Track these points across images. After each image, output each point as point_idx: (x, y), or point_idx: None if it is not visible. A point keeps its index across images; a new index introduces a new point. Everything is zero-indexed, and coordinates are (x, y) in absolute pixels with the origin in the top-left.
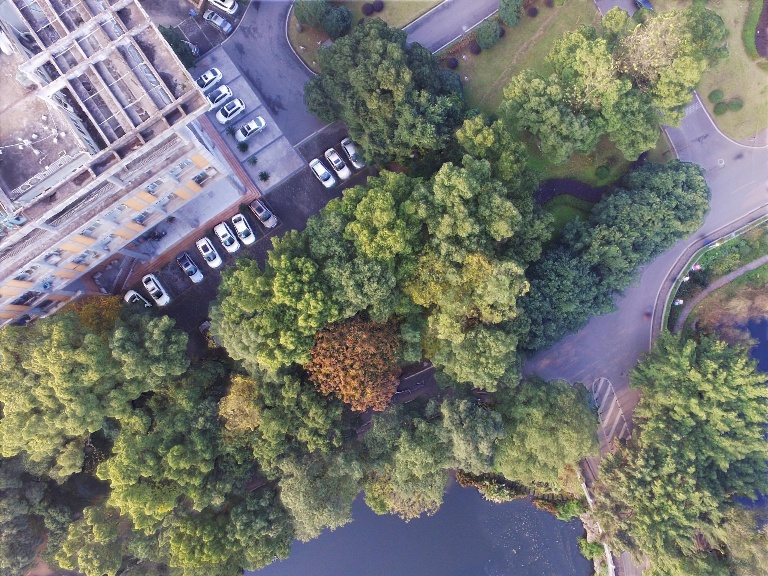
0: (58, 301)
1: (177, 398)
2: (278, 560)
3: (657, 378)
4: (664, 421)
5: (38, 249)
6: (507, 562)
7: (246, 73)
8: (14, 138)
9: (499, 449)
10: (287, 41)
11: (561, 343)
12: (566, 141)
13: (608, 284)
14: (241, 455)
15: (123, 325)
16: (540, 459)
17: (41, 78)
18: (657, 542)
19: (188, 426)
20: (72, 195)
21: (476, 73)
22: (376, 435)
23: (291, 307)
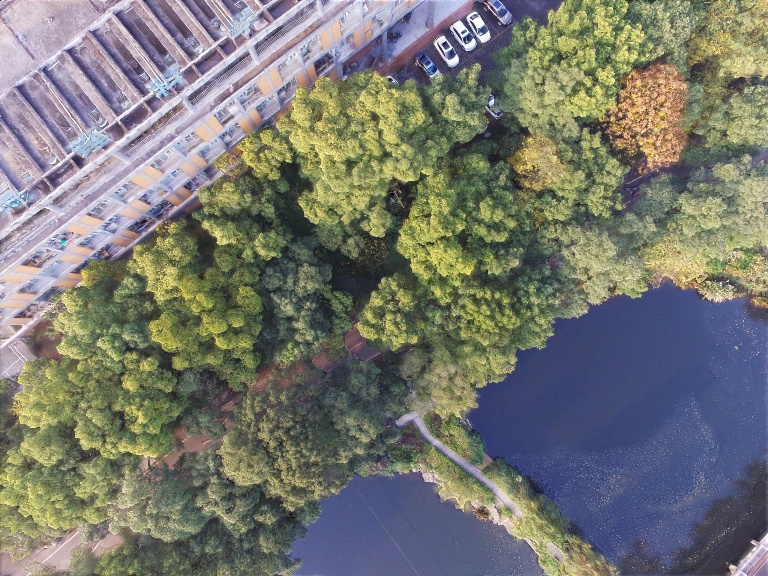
0: None
1: (469, 164)
2: None
3: None
4: None
5: None
6: (730, 358)
7: None
8: None
9: None
10: None
11: None
12: None
13: None
14: (529, 221)
15: (417, 88)
16: None
17: None
18: None
19: (487, 187)
20: None
21: None
22: (652, 201)
23: (605, 45)
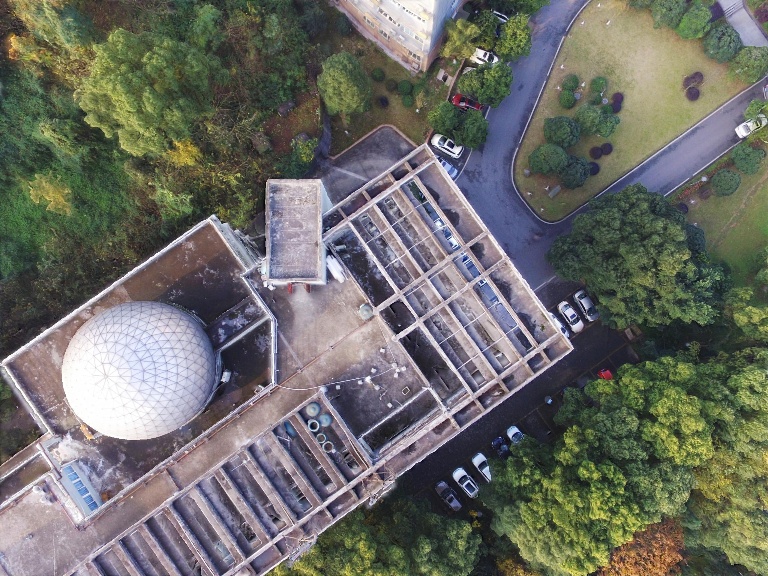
0: None
1: None
2: None
3: None
4: None
5: None
6: None
7: None
8: (352, 372)
9: None
10: (513, 186)
11: None
12: None
13: None
14: None
15: (407, 521)
16: None
17: None
18: None
19: None
20: None
21: (705, 218)
22: None
23: None
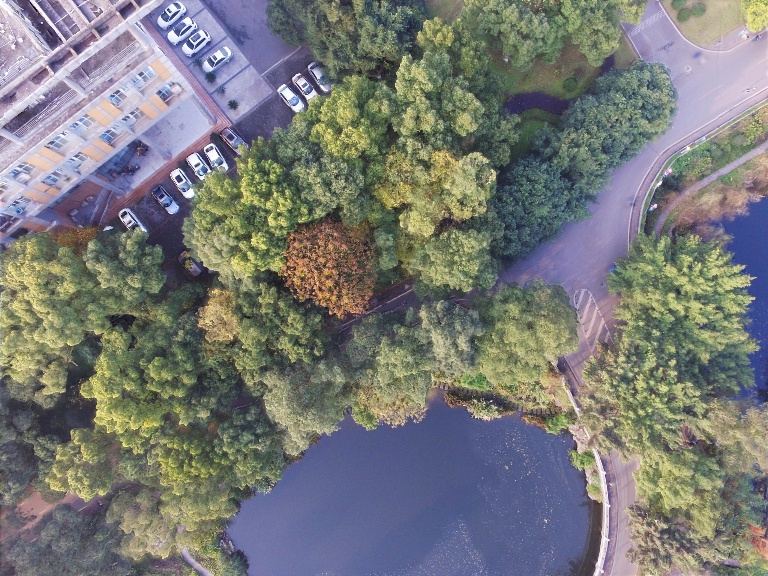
0: (34, 232)
1: (156, 315)
2: (273, 491)
3: (634, 278)
4: (644, 319)
5: (5, 162)
6: (500, 478)
7: (210, 6)
8: None
9: (479, 350)
10: None
11: (540, 257)
12: (527, 40)
13: (580, 189)
14: (224, 369)
15: None
16: (520, 354)
17: None
18: (642, 435)
19: (168, 340)
20: (31, 93)
21: None
22: (357, 344)
23: (261, 209)
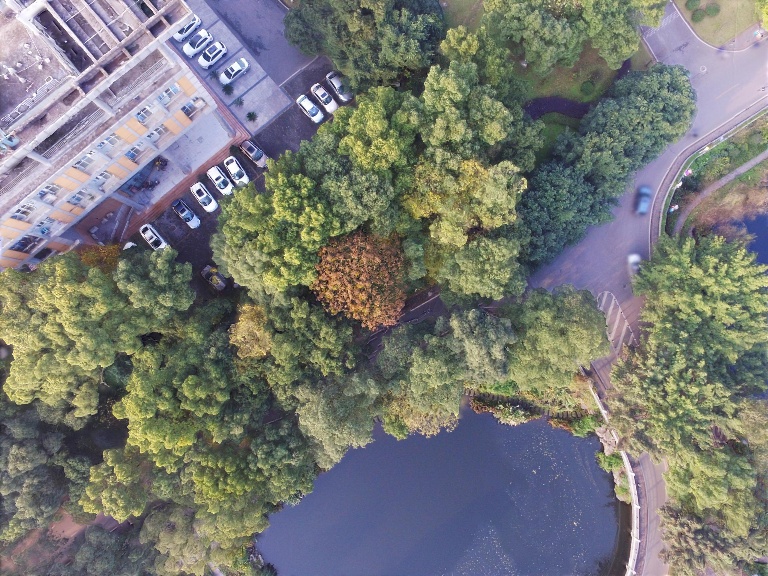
0: (57, 251)
1: (186, 333)
2: (301, 503)
3: (660, 280)
4: (670, 321)
5: (33, 184)
6: (528, 483)
7: (224, 17)
8: None
9: (511, 357)
10: None
11: (562, 261)
12: (550, 46)
13: (603, 192)
14: (255, 385)
15: None
16: (552, 361)
17: (20, 7)
18: (674, 437)
19: (200, 358)
20: (63, 114)
21: None
22: (388, 355)
23: (292, 224)
